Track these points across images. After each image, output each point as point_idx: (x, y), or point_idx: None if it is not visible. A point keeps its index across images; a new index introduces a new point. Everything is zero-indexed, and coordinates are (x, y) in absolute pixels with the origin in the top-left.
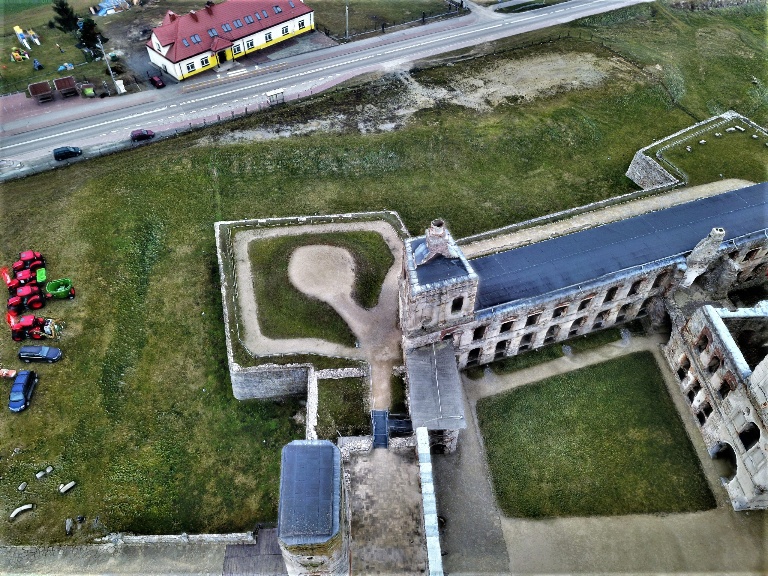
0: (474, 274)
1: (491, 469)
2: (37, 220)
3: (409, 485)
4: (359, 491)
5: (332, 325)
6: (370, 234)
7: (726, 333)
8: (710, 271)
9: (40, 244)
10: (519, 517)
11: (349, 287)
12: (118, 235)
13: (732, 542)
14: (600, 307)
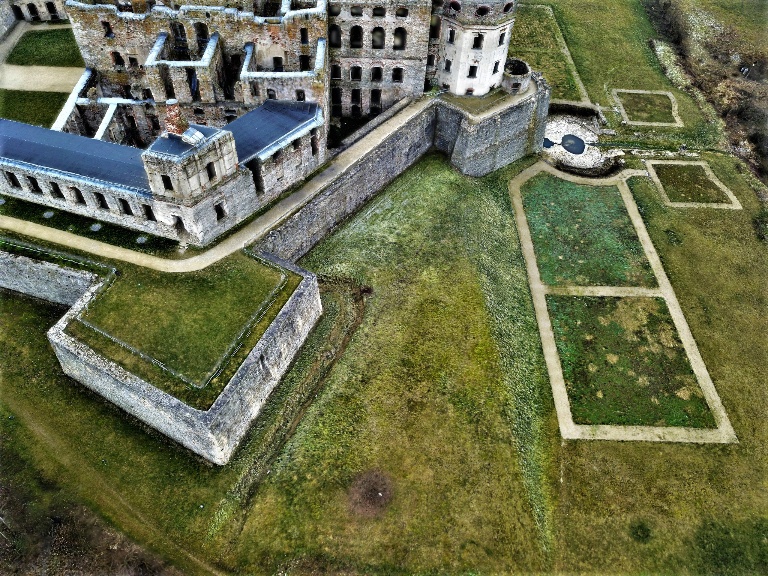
0: None
1: (13, 51)
2: None
3: None
4: None
5: None
6: None
7: None
8: None
9: None
10: (13, 64)
11: None
12: None
13: None
14: None
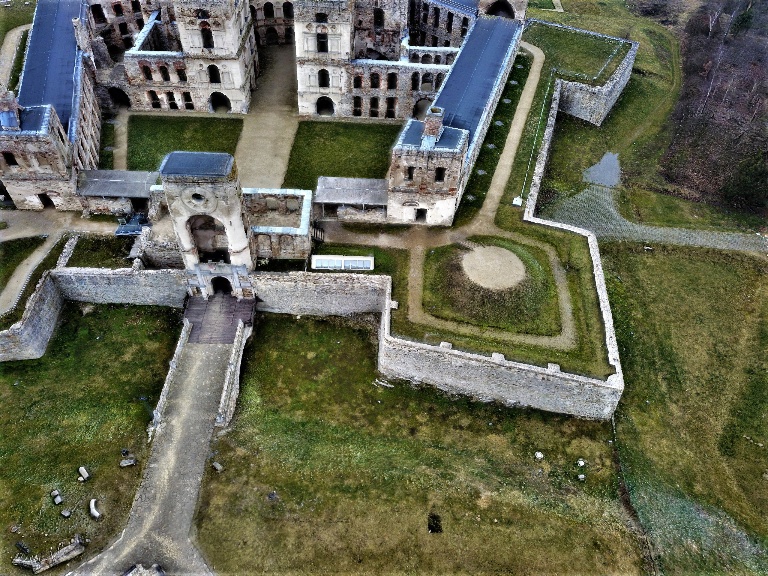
0: (47, 105)
1: None
2: None
3: None
4: None
5: (11, 251)
6: None
7: (150, 52)
8: (93, 54)
9: None
10: None
11: None
12: None
13: (262, 120)
14: (90, 109)
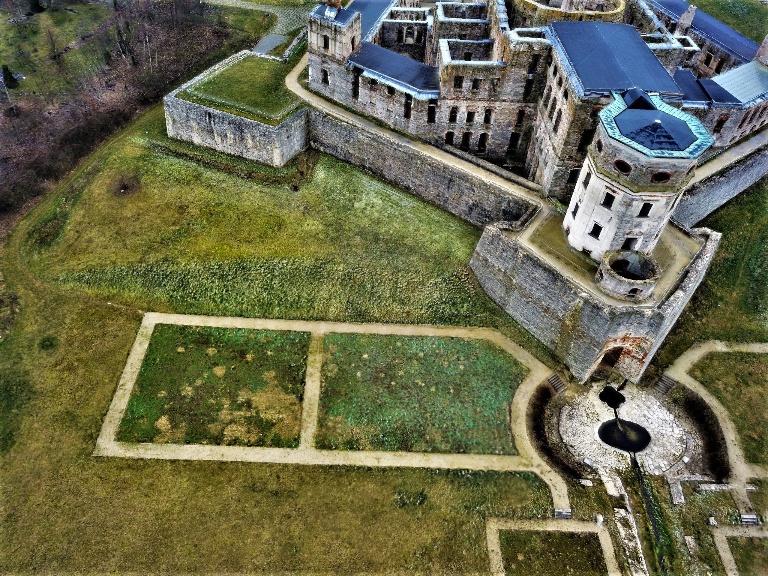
0: None
1: None
2: None
3: None
4: None
5: None
6: None
7: None
8: None
9: None
10: None
11: None
12: None
13: None
14: None
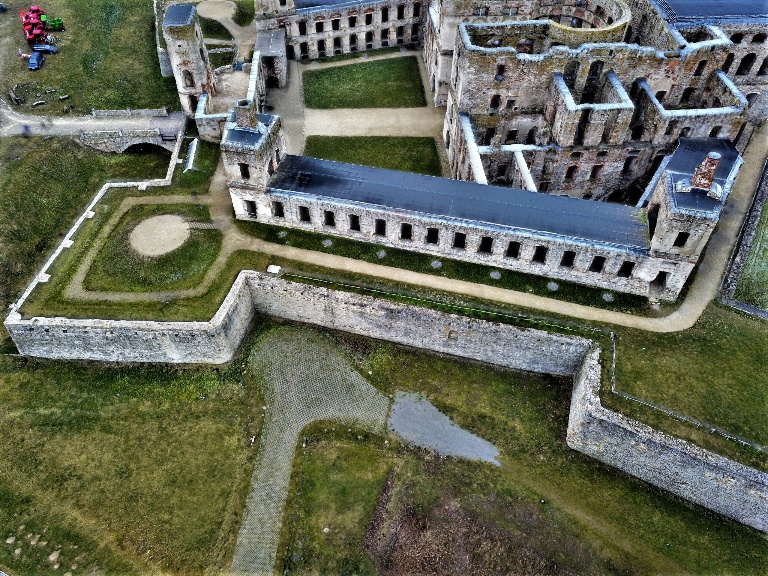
0: None
1: (304, 93)
2: (39, 0)
3: None
4: (223, 83)
5: (219, 32)
6: (252, 1)
7: (435, 16)
8: None
9: None
10: (315, 108)
11: (231, 15)
12: (92, 7)
13: (428, 116)
14: (381, 24)
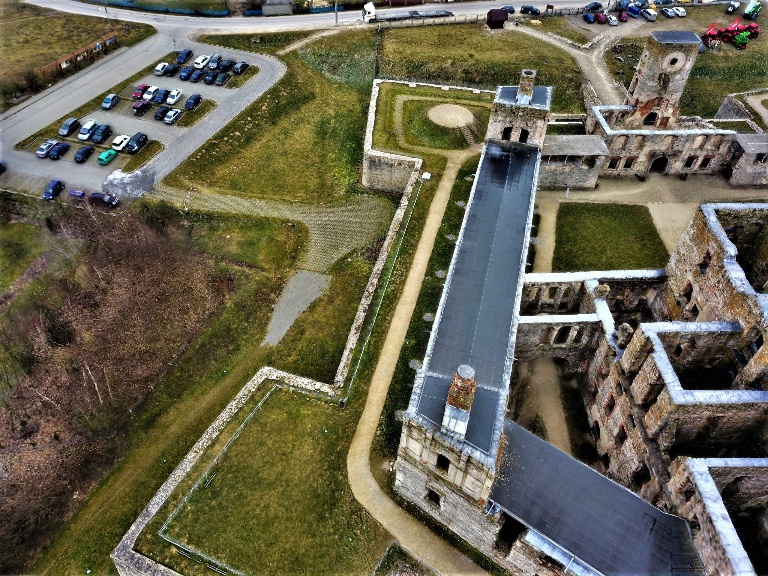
0: None
1: None
2: None
3: (697, 146)
4: None
5: None
6: None
7: None
8: None
9: (767, 34)
10: None
11: None
12: None
13: None
14: None
